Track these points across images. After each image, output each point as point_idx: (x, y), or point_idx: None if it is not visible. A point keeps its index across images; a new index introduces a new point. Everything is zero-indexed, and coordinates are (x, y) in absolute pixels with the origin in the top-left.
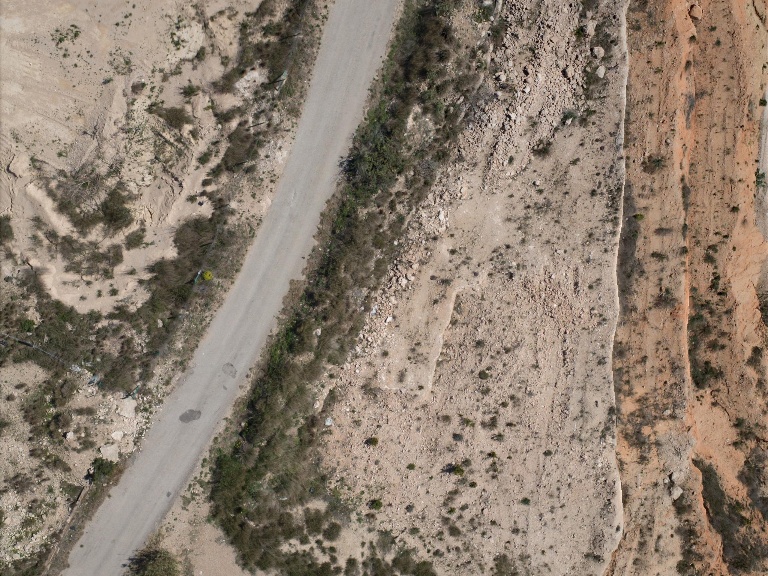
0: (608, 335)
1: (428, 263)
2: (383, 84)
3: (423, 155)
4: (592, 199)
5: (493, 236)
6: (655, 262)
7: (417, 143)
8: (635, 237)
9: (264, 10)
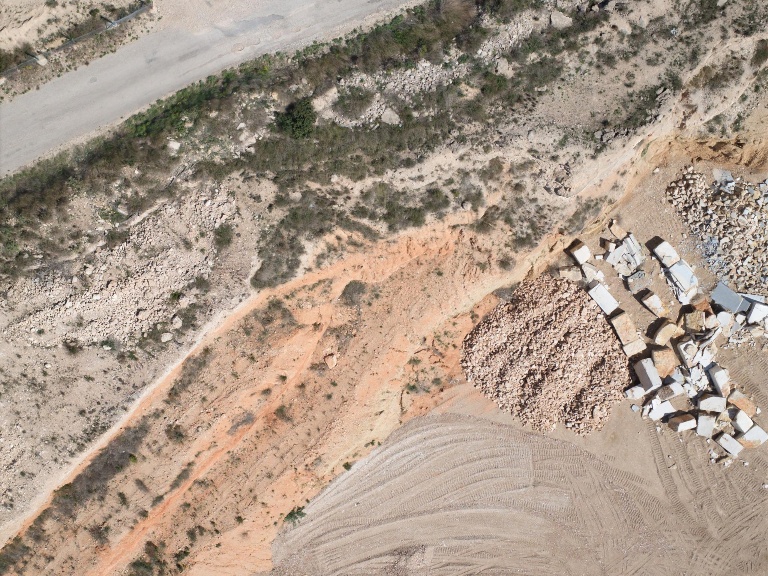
0: (4, 519)
1: None
2: None
3: None
4: (78, 416)
5: None
6: (118, 501)
7: None
8: (118, 470)
9: None
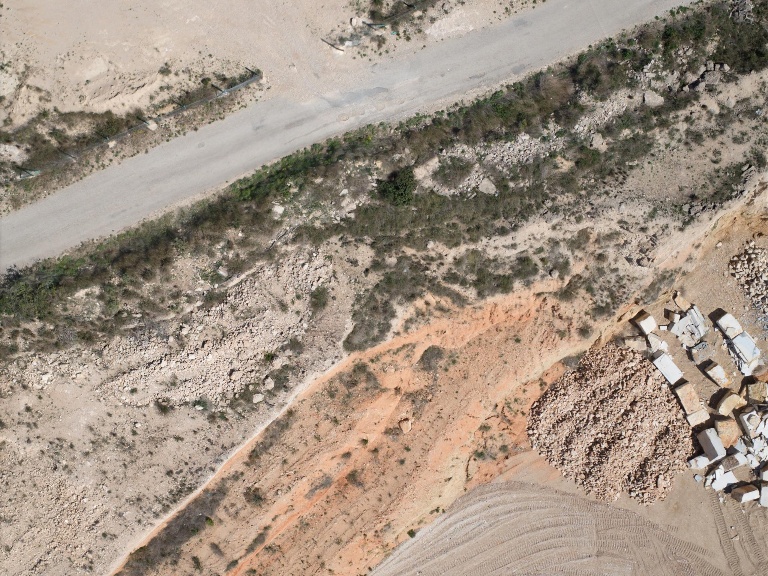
0: None
1: (3, 398)
2: (95, 249)
3: (72, 324)
4: (165, 476)
5: (69, 428)
6: (191, 565)
7: (75, 312)
8: (193, 533)
9: (68, 118)
